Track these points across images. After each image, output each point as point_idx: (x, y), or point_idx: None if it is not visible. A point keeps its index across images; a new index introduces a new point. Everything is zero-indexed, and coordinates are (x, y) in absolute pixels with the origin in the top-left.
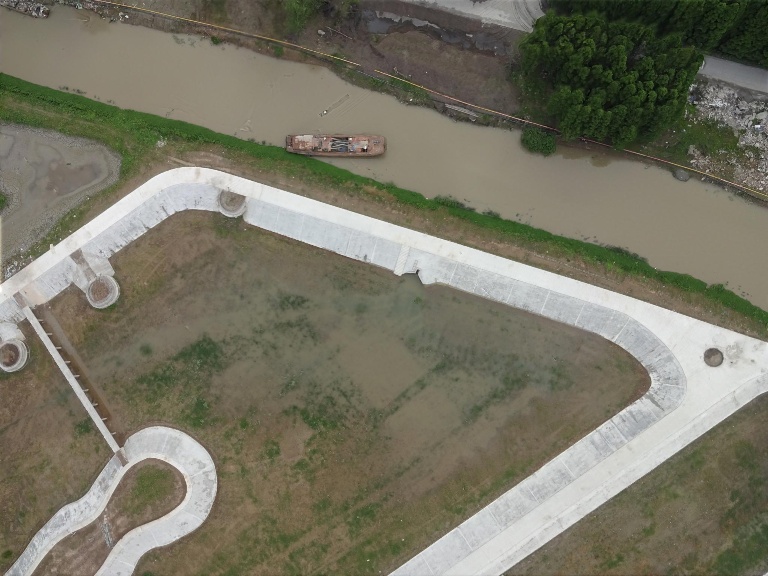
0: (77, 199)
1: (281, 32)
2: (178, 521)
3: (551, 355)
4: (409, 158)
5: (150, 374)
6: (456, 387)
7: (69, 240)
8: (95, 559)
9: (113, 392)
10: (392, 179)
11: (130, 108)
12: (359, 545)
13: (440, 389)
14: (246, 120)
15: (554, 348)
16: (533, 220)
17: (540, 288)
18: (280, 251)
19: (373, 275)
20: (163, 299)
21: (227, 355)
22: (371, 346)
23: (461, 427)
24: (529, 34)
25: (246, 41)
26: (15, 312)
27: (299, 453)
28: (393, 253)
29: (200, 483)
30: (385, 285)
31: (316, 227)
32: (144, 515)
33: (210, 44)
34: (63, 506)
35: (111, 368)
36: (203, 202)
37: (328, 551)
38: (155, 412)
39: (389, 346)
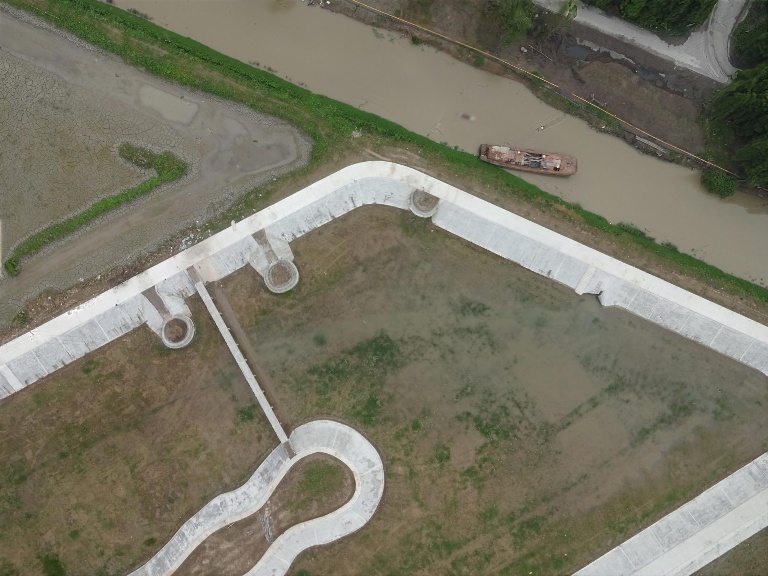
0: (262, 178)
1: (484, 43)
2: (343, 520)
3: (716, 386)
4: (595, 182)
5: (322, 366)
6: (626, 408)
7: (253, 219)
8: (252, 553)
9: (281, 380)
10: (578, 200)
11: (323, 94)
12: (523, 557)
13: (611, 409)
14: (436, 123)
15: (719, 380)
16: (707, 256)
17: (715, 322)
18: (465, 256)
19: (555, 291)
20: (342, 291)
21: (404, 354)
22: (547, 360)
23: (628, 448)
24: (717, 82)
25: (448, 46)
26: (185, 286)
27: (469, 460)
28: (578, 272)
29: (368, 482)
30: (566, 302)
31: (506, 237)
32: (309, 511)
33: (410, 43)
34: (218, 495)
35: (281, 355)
36: (393, 198)
37: (491, 561)
38: (325, 405)
39: (565, 362)
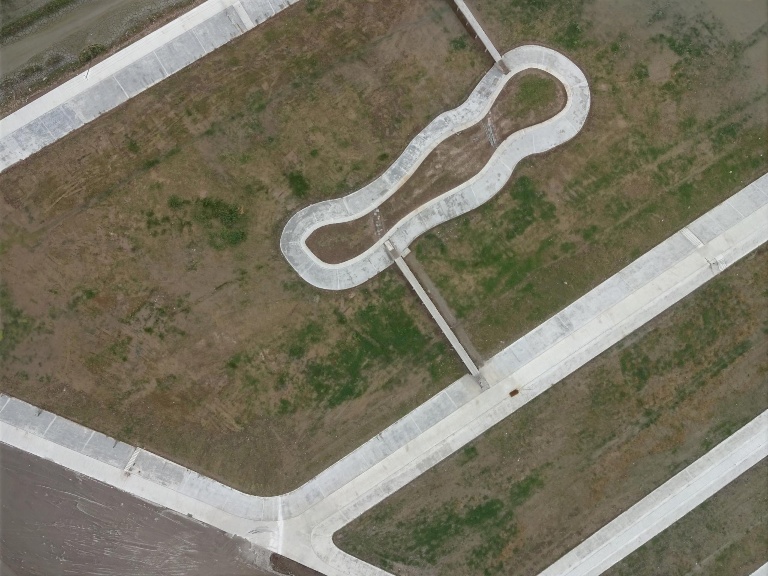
0: None
1: None
2: (558, 127)
3: None
4: None
5: None
6: None
7: None
8: (480, 157)
9: (487, 12)
10: None
11: None
12: (722, 158)
13: None
14: None
15: None
16: None
17: None
18: None
19: None
20: None
21: None
22: None
23: None
24: None
25: None
26: None
27: (666, 76)
28: None
29: (578, 95)
30: None
31: None
32: (528, 119)
33: None
34: (441, 113)
35: None
36: None
37: (693, 163)
38: (529, 32)
39: None
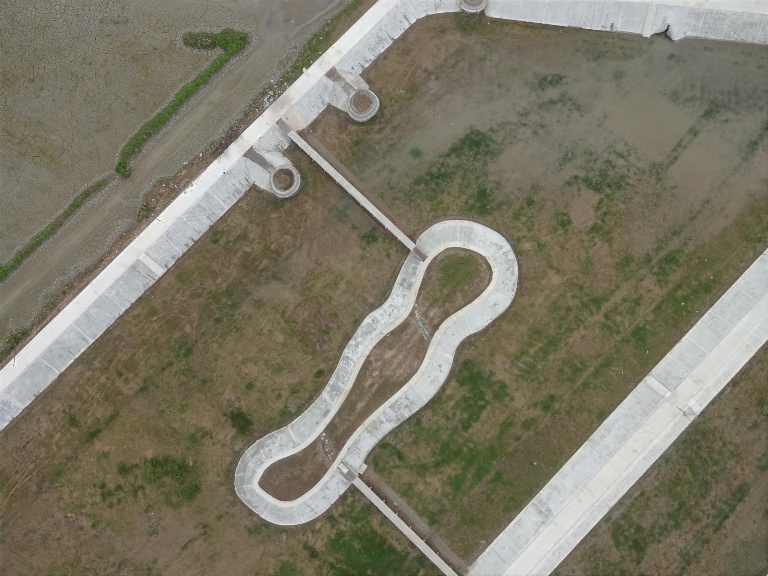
0: (317, 25)
1: None
2: (489, 302)
3: None
4: None
5: (425, 174)
6: (727, 128)
7: (321, 61)
8: (416, 354)
9: (392, 198)
10: None
11: None
12: (671, 291)
13: (713, 132)
14: None
15: None
16: None
17: None
18: (527, 37)
19: (623, 41)
20: (422, 102)
21: (498, 142)
22: (636, 107)
23: (741, 163)
24: None
25: None
26: (279, 140)
27: (591, 218)
28: (640, 15)
29: (502, 263)
30: (637, 48)
31: (560, 5)
32: (456, 302)
33: None
34: (367, 315)
35: (385, 177)
36: (443, 4)
37: (641, 304)
38: (439, 208)
39: (653, 103)
